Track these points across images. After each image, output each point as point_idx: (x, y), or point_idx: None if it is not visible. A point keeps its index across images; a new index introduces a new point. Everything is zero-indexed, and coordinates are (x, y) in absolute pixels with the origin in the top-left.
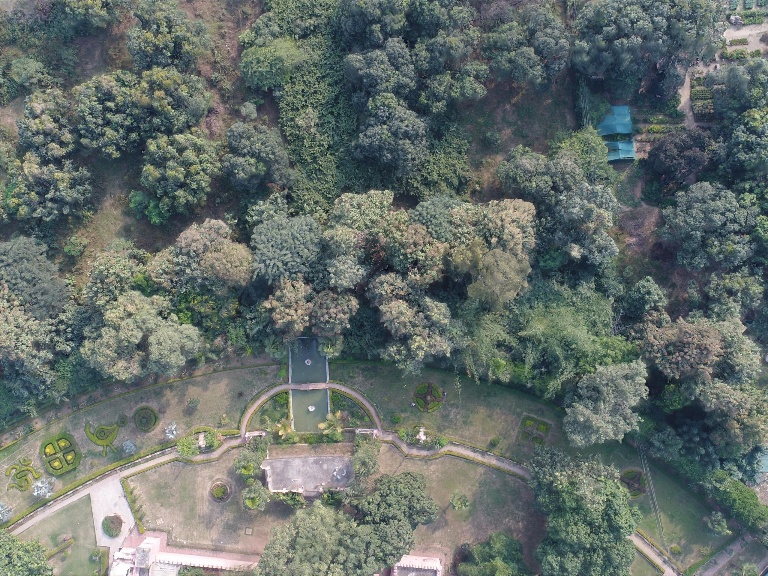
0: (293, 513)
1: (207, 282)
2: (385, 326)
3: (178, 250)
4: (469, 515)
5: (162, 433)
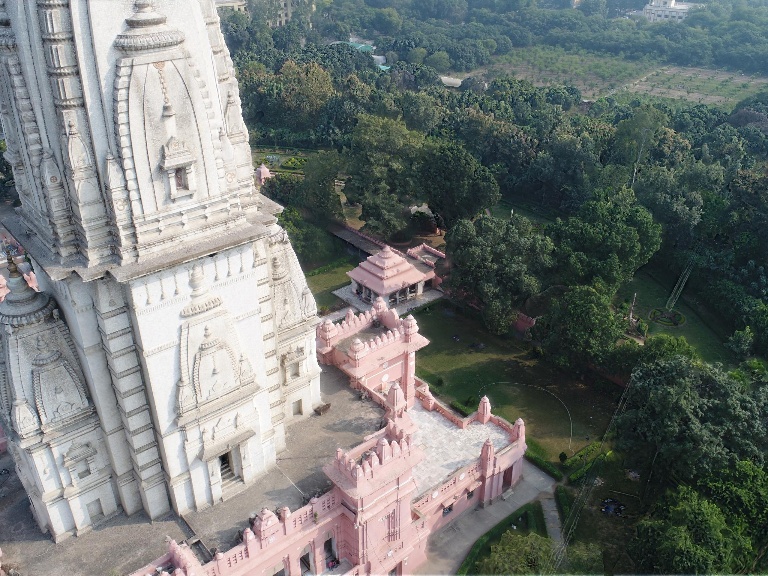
0: None
1: (461, 123)
2: (540, 183)
3: None
4: None
5: None
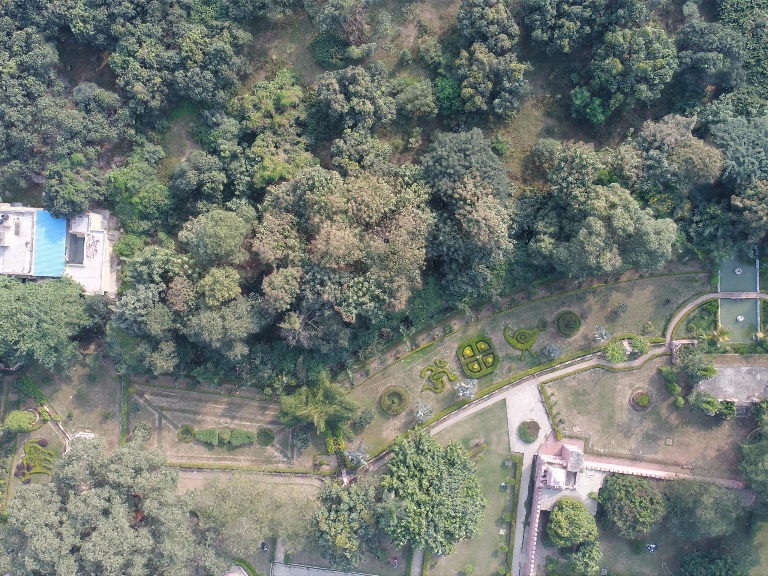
0: (716, 425)
1: (674, 178)
2: None
3: (646, 144)
4: None
5: (583, 339)
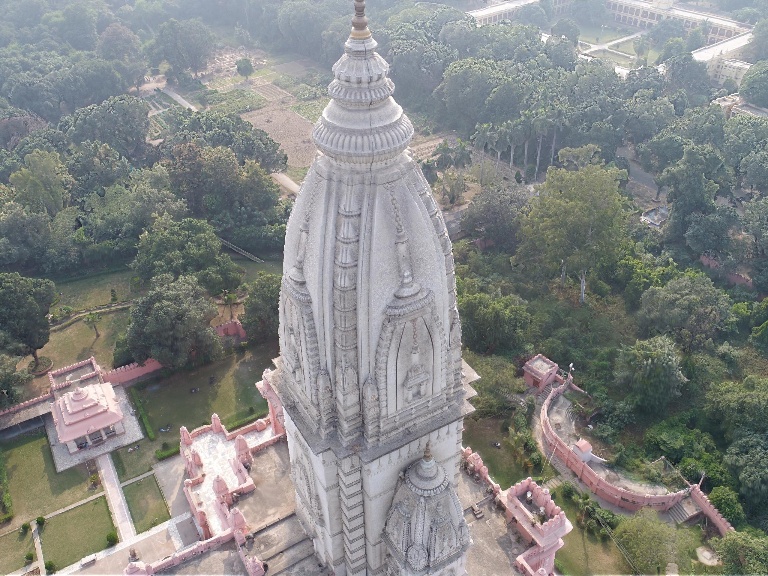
0: None
1: None
2: None
3: None
4: (114, 341)
5: None
